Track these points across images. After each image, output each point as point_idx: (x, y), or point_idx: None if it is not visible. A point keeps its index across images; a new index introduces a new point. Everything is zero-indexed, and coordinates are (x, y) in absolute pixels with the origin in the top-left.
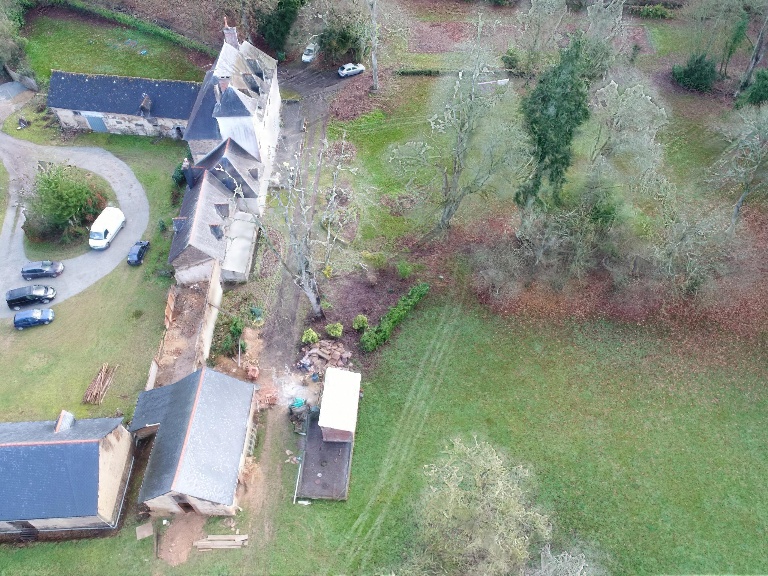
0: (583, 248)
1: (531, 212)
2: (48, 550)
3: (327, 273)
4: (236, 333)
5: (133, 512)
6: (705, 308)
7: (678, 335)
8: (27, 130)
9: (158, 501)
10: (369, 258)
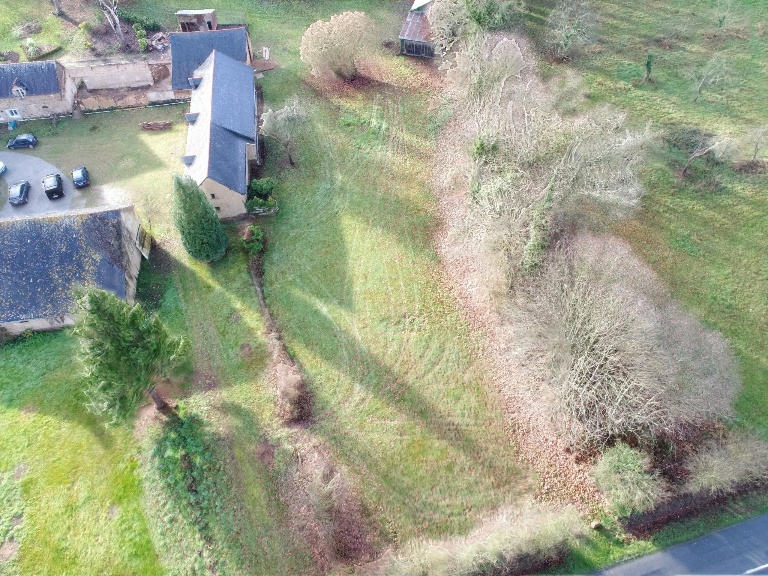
0: None
1: None
2: (268, 104)
3: None
4: None
5: None
6: None
7: None
8: None
9: None
10: (86, 24)
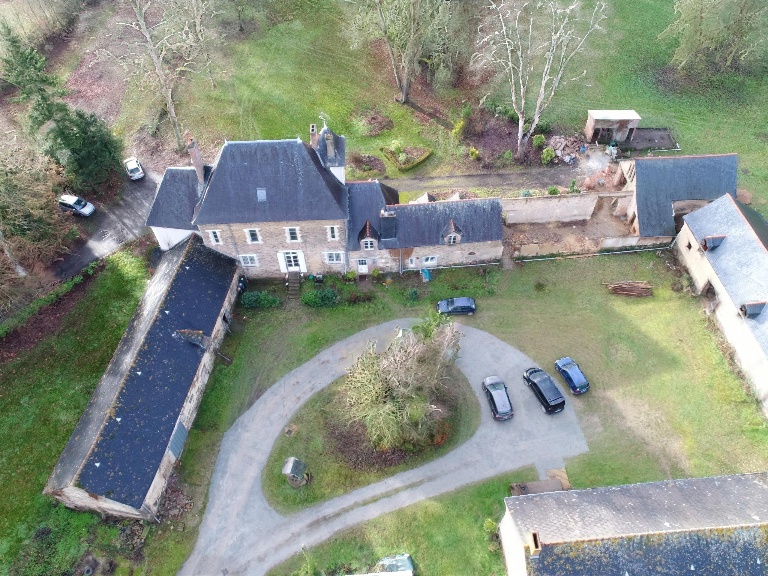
0: None
1: None
2: None
3: None
4: None
5: None
6: None
7: None
8: None
9: None
10: (463, 123)
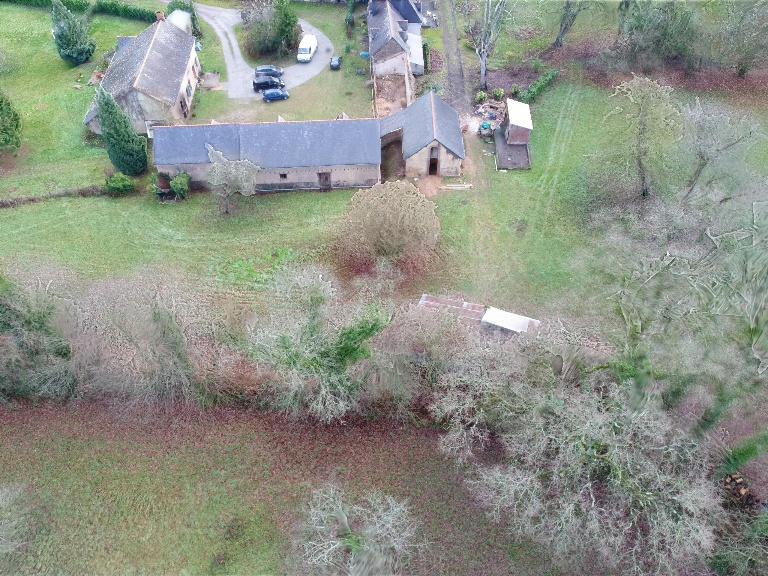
0: (673, 29)
1: (630, 17)
2: (344, 192)
3: None
4: None
5: (393, 175)
6: (753, 83)
7: (736, 96)
8: None
9: (418, 157)
10: (512, 56)
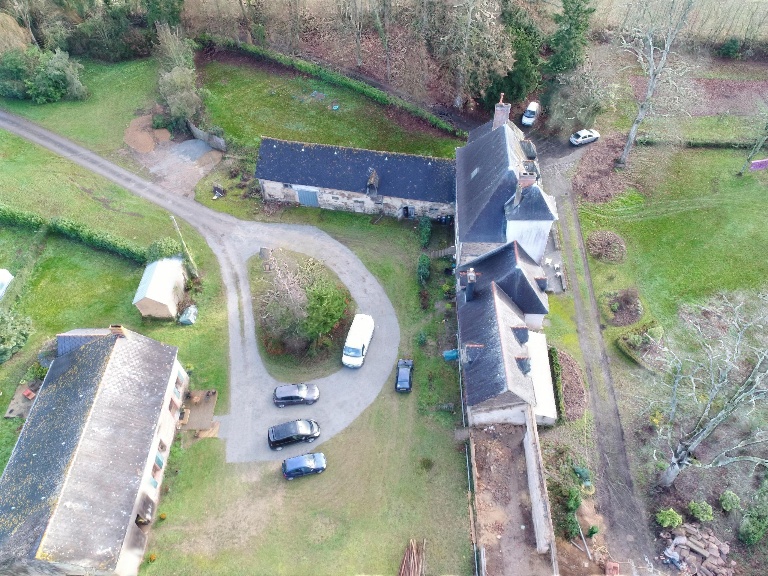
0: None
1: None
2: None
3: (657, 422)
4: (575, 509)
5: None
6: None
7: None
8: (224, 200)
9: None
10: (712, 406)
